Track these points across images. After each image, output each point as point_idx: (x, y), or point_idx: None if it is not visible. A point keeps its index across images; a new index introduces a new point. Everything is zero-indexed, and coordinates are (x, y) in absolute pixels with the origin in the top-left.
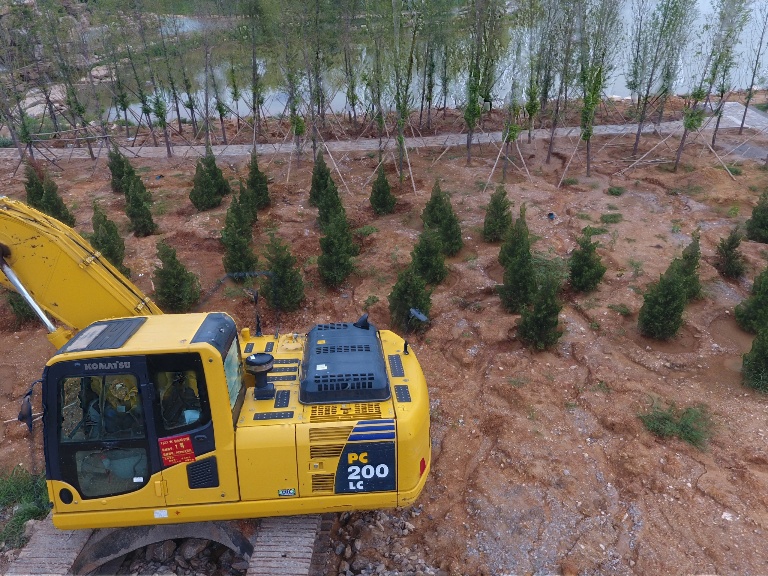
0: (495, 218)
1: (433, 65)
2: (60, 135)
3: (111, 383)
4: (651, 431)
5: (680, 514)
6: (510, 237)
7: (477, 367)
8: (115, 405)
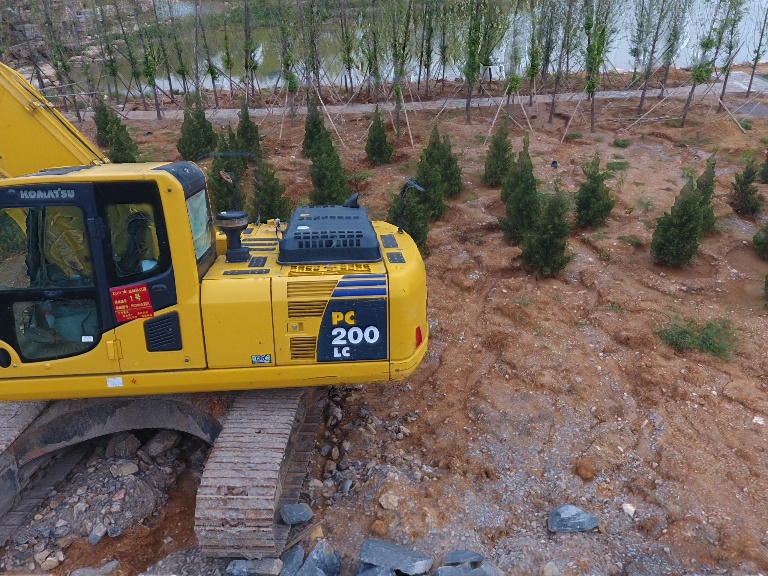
0: (496, 160)
1: (431, 29)
2: (45, 92)
3: (53, 218)
4: (670, 344)
5: (706, 418)
6: (513, 172)
7: (478, 293)
8: (68, 273)
